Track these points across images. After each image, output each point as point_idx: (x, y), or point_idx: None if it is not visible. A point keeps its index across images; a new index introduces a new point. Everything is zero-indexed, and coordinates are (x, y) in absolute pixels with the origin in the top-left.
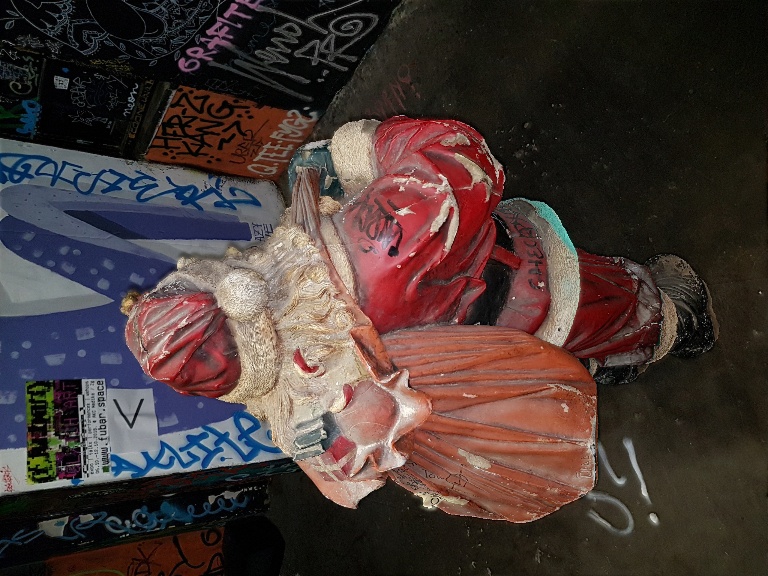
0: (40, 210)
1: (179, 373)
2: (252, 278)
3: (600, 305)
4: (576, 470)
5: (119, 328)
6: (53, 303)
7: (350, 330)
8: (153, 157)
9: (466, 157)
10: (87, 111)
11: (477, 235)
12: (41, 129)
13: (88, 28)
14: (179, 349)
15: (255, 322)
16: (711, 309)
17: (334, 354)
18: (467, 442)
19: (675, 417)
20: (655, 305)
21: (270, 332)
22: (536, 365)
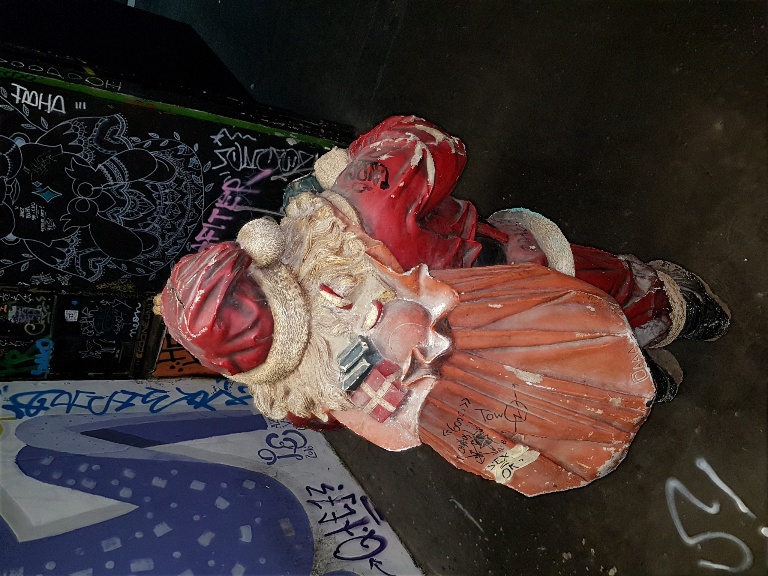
0: (57, 436)
1: (215, 320)
2: (267, 220)
3: (598, 272)
4: (629, 372)
5: (147, 533)
6: (76, 519)
7: (364, 252)
8: (161, 373)
9: (425, 127)
10: (96, 344)
11: (459, 210)
12: (54, 370)
13: (93, 256)
14: (212, 287)
15: (277, 272)
16: (711, 293)
17: (356, 286)
18: (509, 354)
19: (733, 412)
20: (651, 275)
21: (293, 281)
22: (550, 284)
